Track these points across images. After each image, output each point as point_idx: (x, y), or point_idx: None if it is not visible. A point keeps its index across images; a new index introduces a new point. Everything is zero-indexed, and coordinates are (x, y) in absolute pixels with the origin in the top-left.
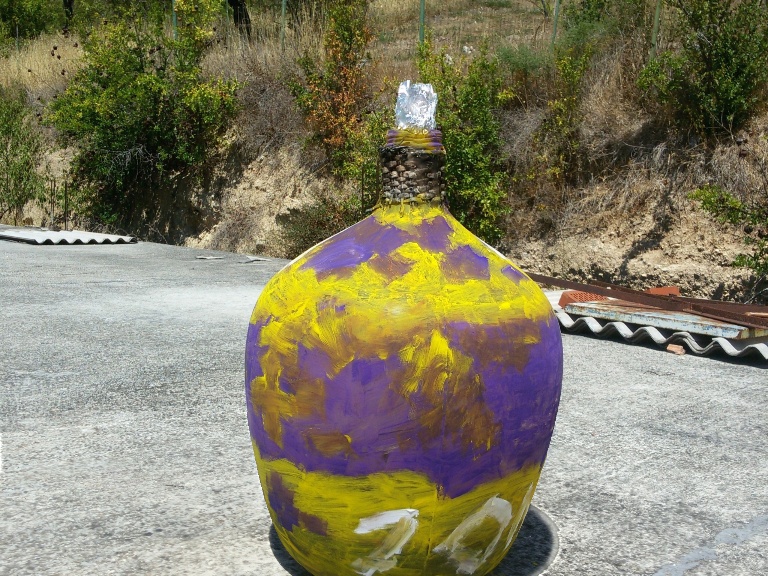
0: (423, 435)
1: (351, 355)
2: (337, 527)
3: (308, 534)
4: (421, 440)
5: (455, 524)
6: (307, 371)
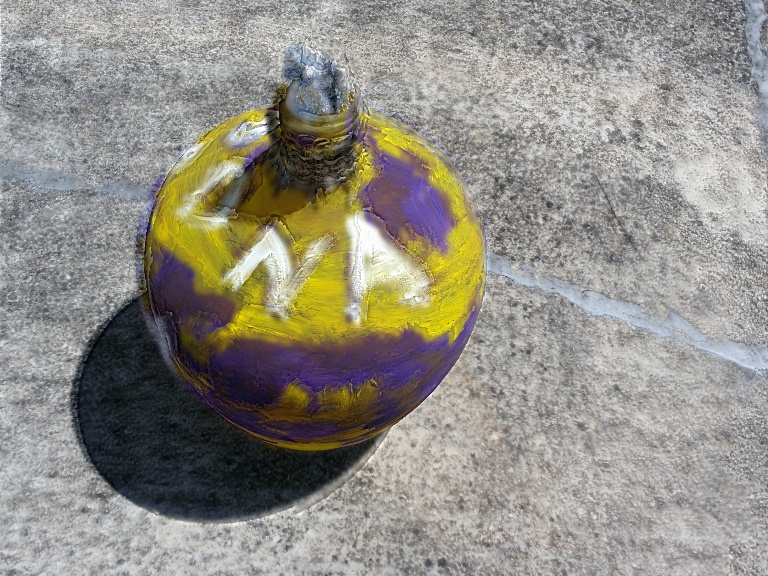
0: None
1: None
2: None
3: None
4: None
5: None
6: None
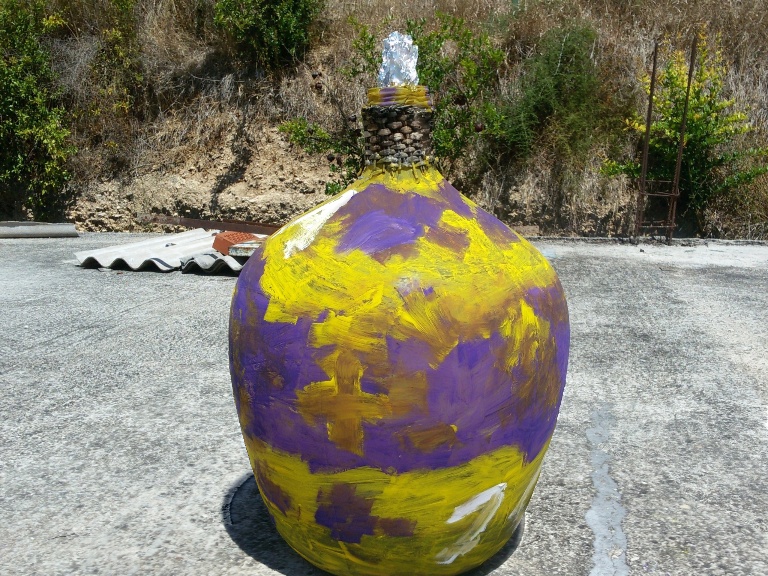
0: (520, 407)
1: (455, 339)
2: (428, 523)
3: (387, 540)
4: (518, 413)
5: (525, 487)
6: (404, 365)
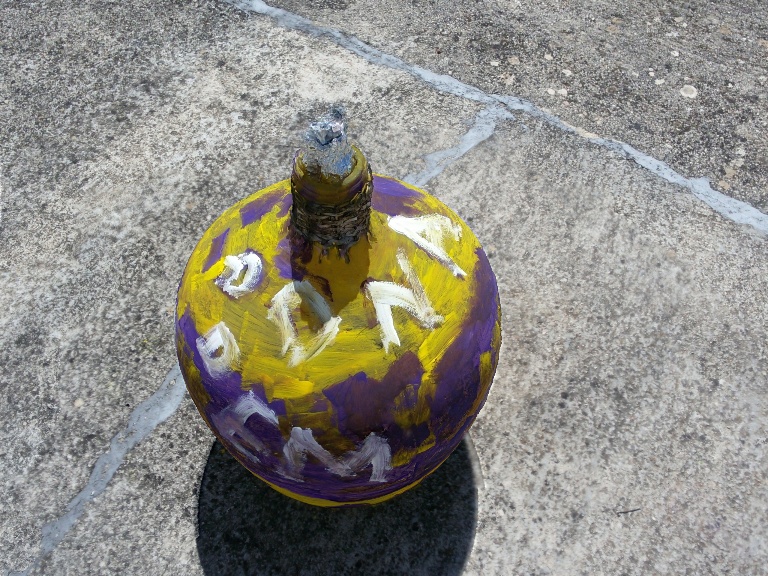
0: None
1: None
2: None
3: None
4: None
5: None
6: None
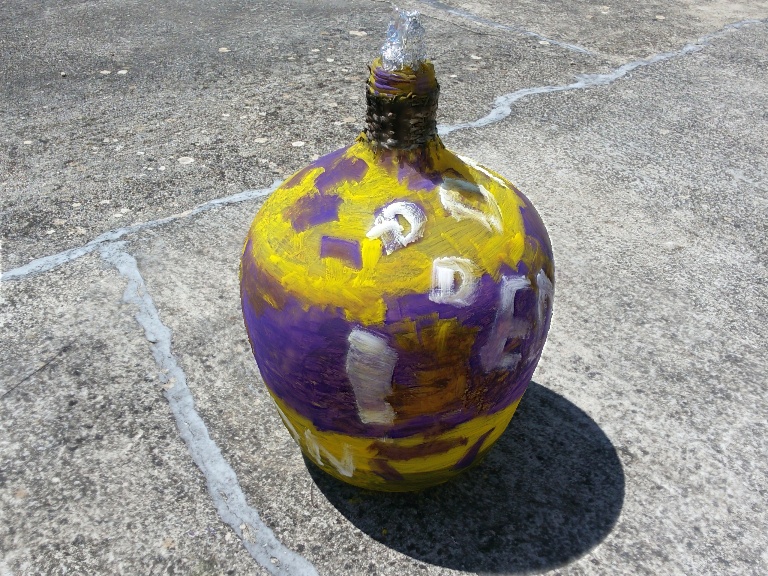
0: None
1: None
2: None
3: None
4: None
5: None
6: None
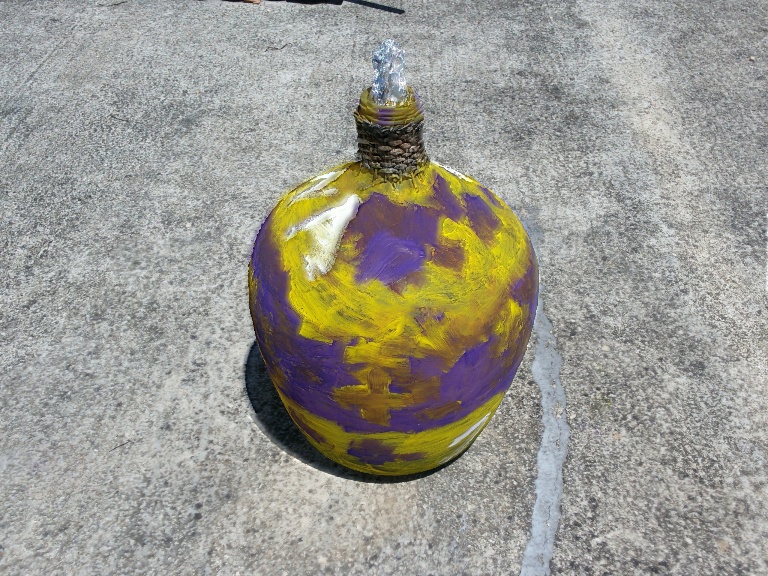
0: None
1: (463, 350)
2: None
3: (404, 463)
4: None
5: None
6: (424, 375)
